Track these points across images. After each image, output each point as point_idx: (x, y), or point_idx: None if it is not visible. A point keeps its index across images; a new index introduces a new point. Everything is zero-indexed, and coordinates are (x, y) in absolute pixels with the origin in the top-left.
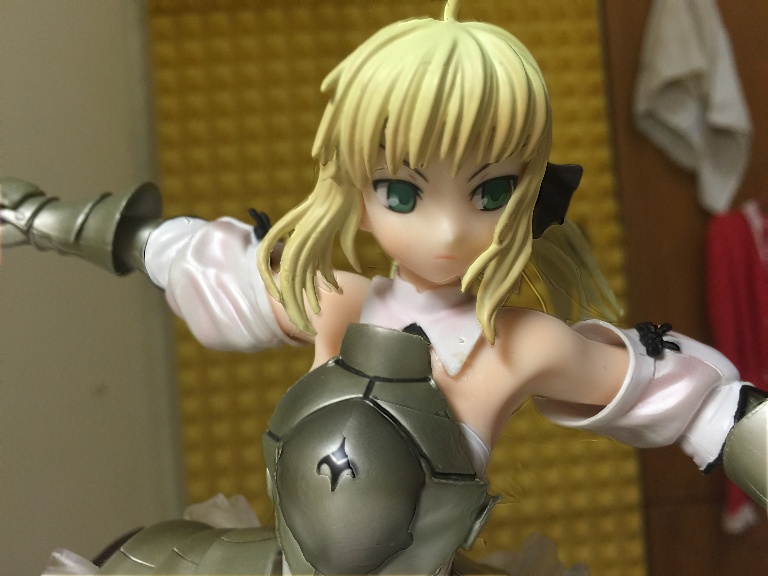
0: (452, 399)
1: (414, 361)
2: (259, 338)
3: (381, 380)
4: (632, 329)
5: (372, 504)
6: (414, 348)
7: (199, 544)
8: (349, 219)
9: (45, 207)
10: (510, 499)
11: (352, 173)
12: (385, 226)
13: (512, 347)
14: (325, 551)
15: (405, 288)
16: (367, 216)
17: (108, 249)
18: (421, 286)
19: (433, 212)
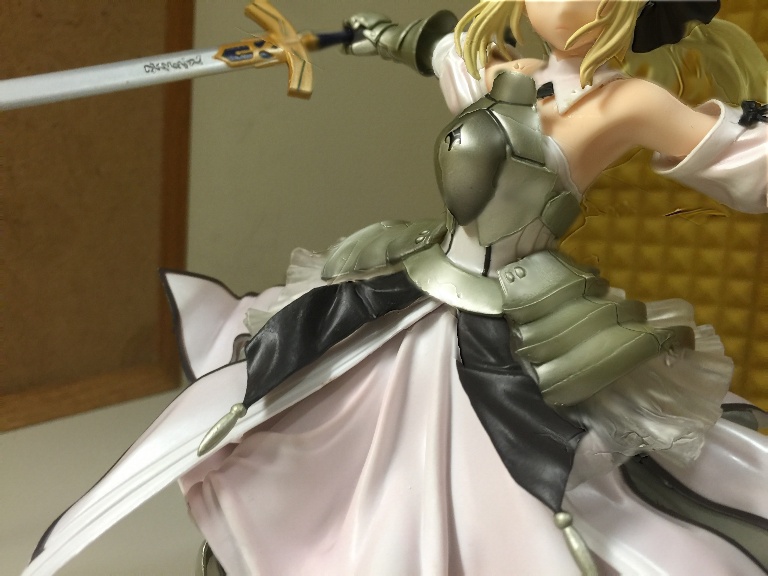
0: (554, 126)
1: (525, 93)
2: None
3: (502, 103)
4: (739, 106)
5: (471, 164)
6: (526, 85)
7: None
8: (515, 7)
9: (388, 29)
10: (599, 212)
11: None
12: (530, 9)
13: (610, 100)
14: (449, 194)
15: (552, 60)
16: None
17: (413, 53)
18: (560, 57)
19: None
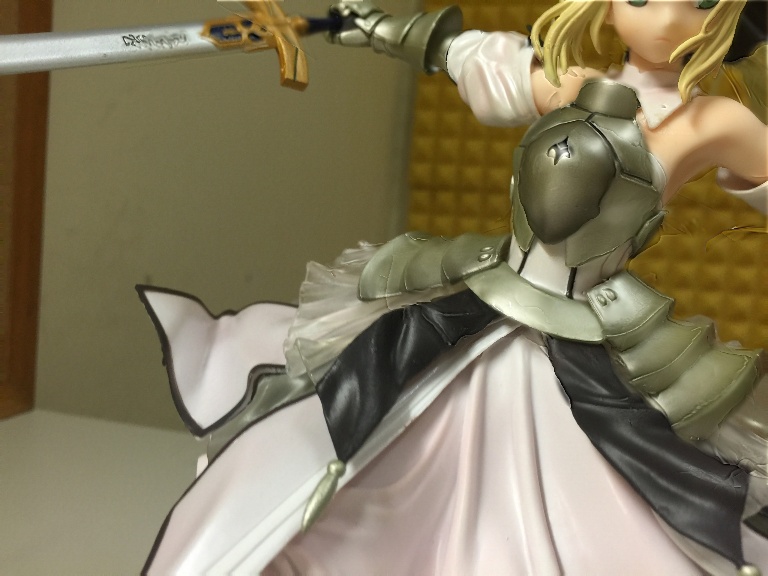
0: (648, 142)
1: (625, 106)
2: (519, 112)
3: (599, 114)
4: None
5: (578, 180)
6: (626, 97)
7: (457, 234)
8: (599, 12)
9: (384, 19)
10: (679, 231)
11: None
12: (623, 16)
13: (702, 117)
14: (542, 211)
15: (631, 71)
16: (612, 11)
17: (423, 48)
18: (643, 68)
19: (659, 5)
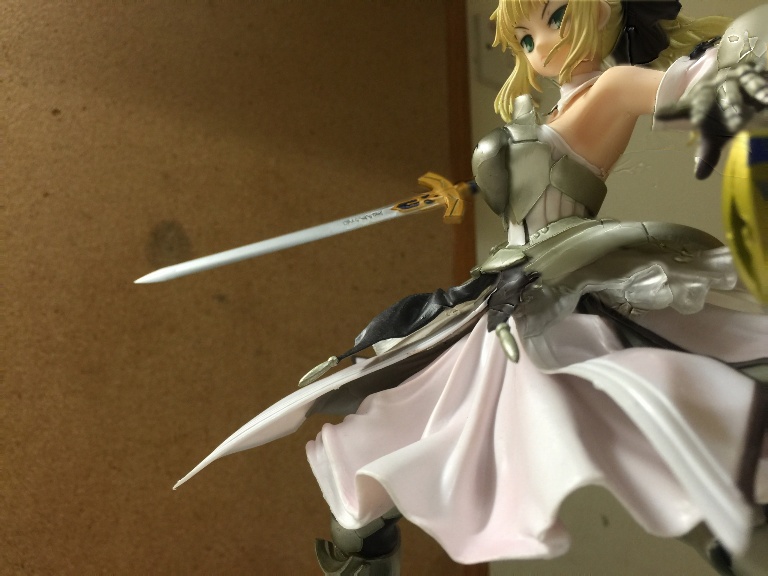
0: None
1: (525, 106)
2: None
3: None
4: None
5: None
6: (525, 101)
7: None
8: None
9: None
10: None
11: (511, 45)
12: None
13: None
14: (486, 192)
15: None
16: None
17: None
18: None
19: None
